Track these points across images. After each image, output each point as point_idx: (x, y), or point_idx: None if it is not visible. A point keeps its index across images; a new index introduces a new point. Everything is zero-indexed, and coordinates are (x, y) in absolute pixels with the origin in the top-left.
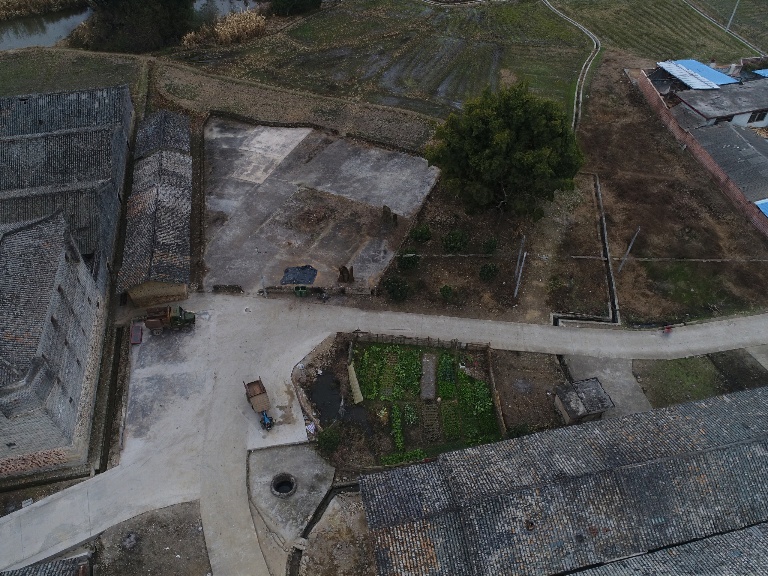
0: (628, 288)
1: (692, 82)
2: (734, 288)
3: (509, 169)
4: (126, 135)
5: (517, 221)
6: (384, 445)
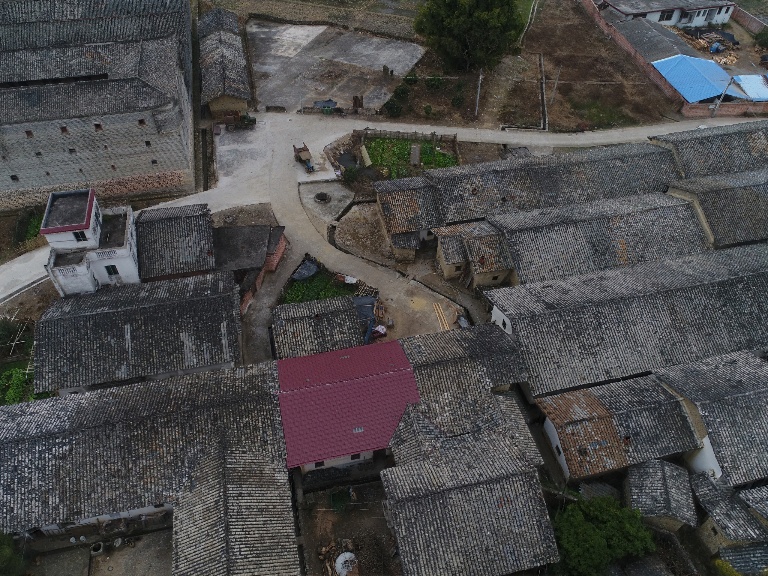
0: (556, 112)
1: None
2: (630, 113)
3: (471, 25)
4: (190, 25)
5: (479, 72)
6: None
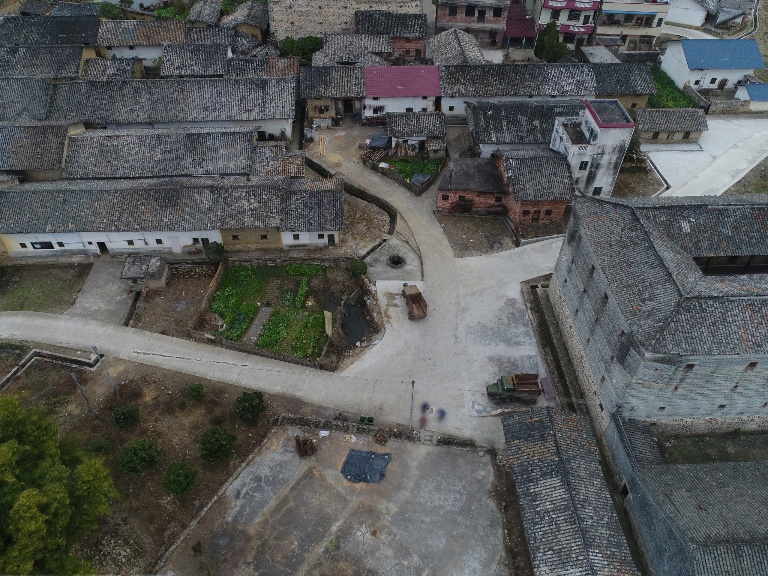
0: None
1: None
2: None
3: None
4: None
5: None
6: (317, 282)
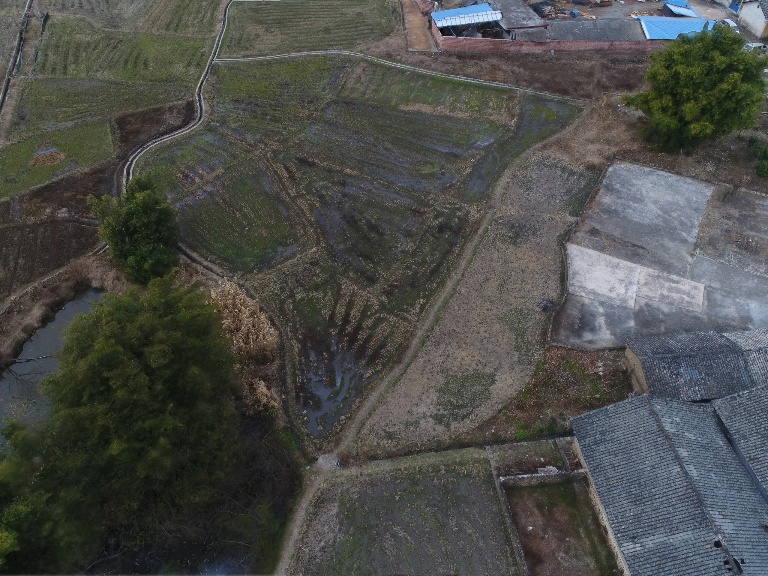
0: None
1: (488, 18)
2: None
3: None
4: None
5: None
6: None
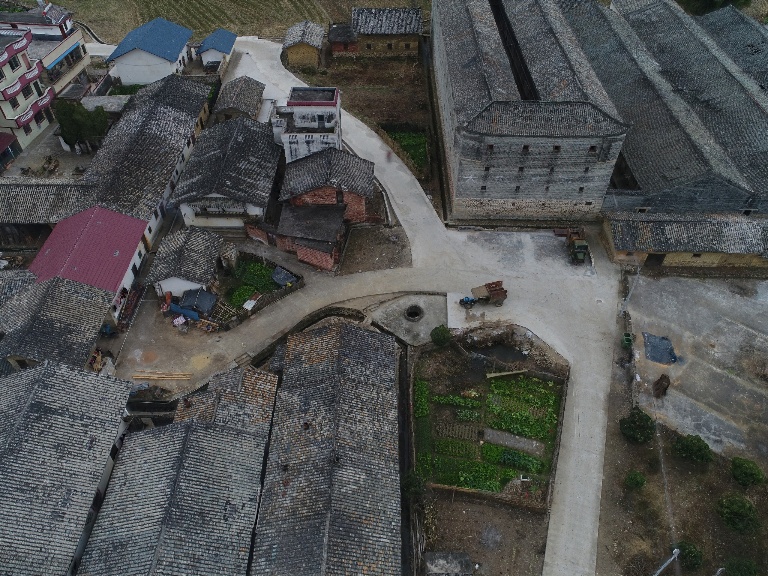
0: None
1: None
2: None
3: None
4: None
5: None
6: (439, 387)
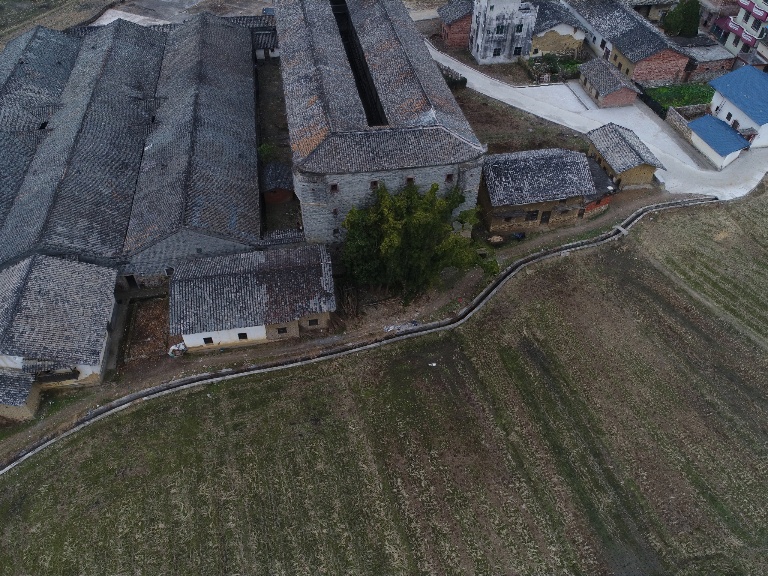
0: None
1: None
2: None
3: None
4: None
5: None
6: None
